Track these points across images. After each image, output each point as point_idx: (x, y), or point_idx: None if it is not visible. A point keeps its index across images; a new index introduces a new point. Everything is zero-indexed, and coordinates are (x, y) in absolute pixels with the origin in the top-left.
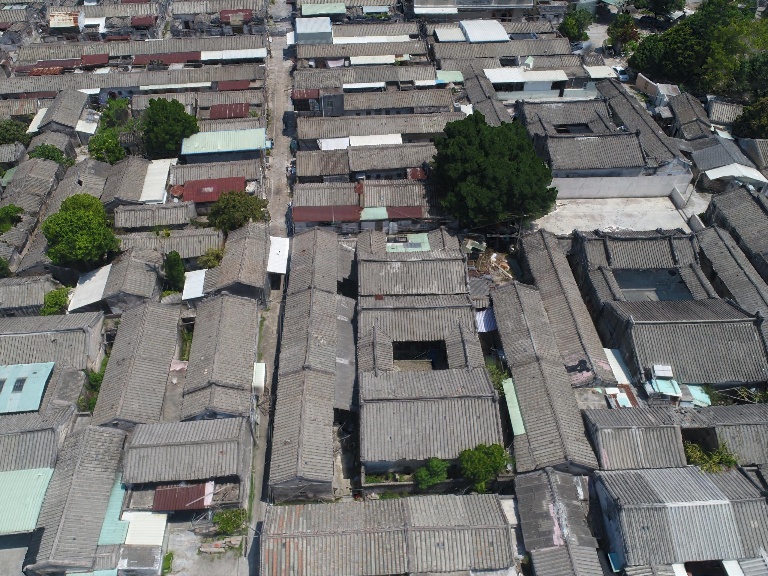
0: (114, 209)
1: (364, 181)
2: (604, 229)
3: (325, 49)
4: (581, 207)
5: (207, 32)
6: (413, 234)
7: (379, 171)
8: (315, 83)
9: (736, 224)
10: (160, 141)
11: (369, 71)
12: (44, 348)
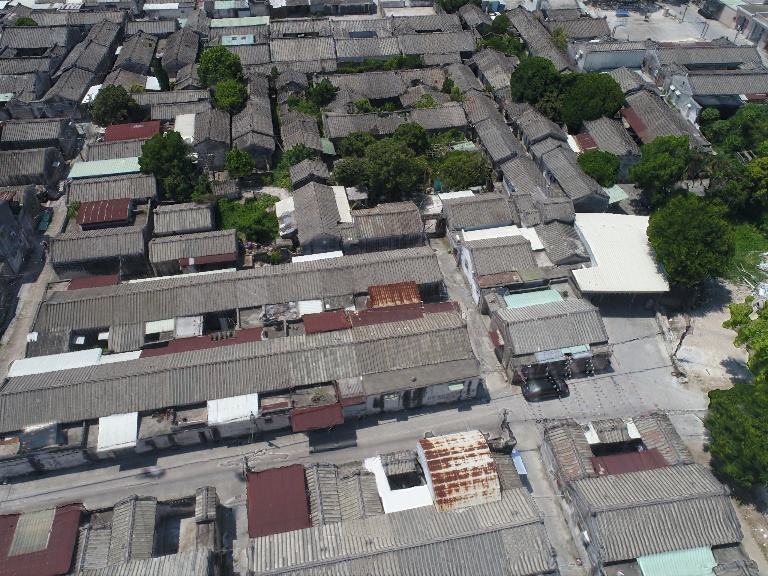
0: None
1: None
2: None
3: None
4: None
5: None
6: None
7: None
8: None
9: None
10: None
11: None
12: None
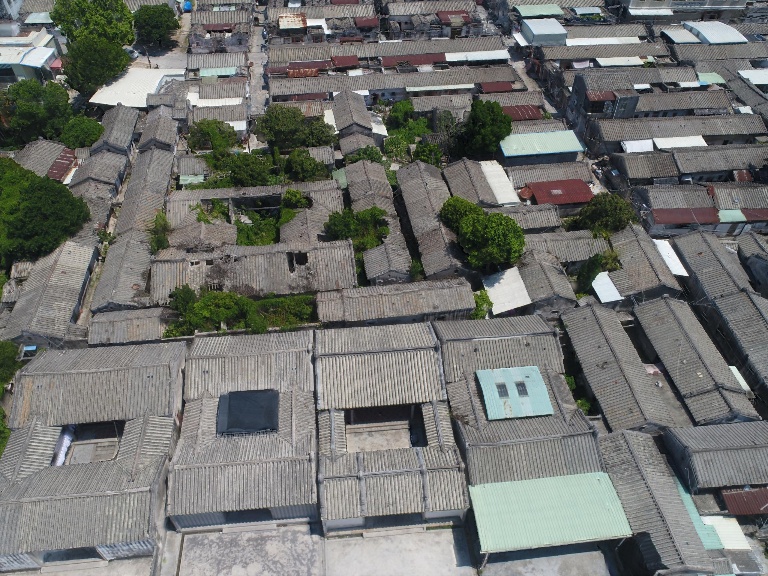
0: (488, 212)
1: (703, 183)
2: None
3: (570, 51)
4: None
5: (427, 33)
6: None
7: (704, 173)
8: (607, 85)
9: None
10: (484, 143)
11: (631, 73)
12: (520, 352)
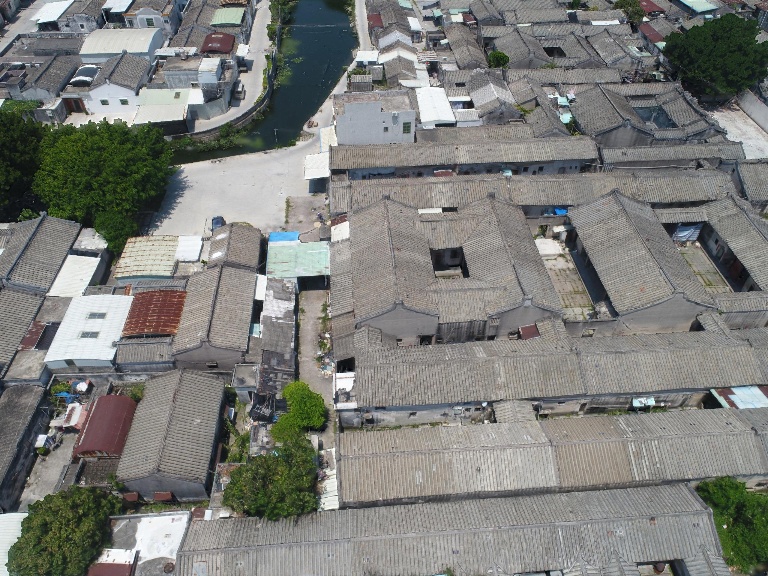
0: None
1: None
2: (731, 137)
3: None
4: (754, 131)
5: None
6: (650, 54)
7: None
8: None
9: (757, 159)
10: None
11: None
12: None
